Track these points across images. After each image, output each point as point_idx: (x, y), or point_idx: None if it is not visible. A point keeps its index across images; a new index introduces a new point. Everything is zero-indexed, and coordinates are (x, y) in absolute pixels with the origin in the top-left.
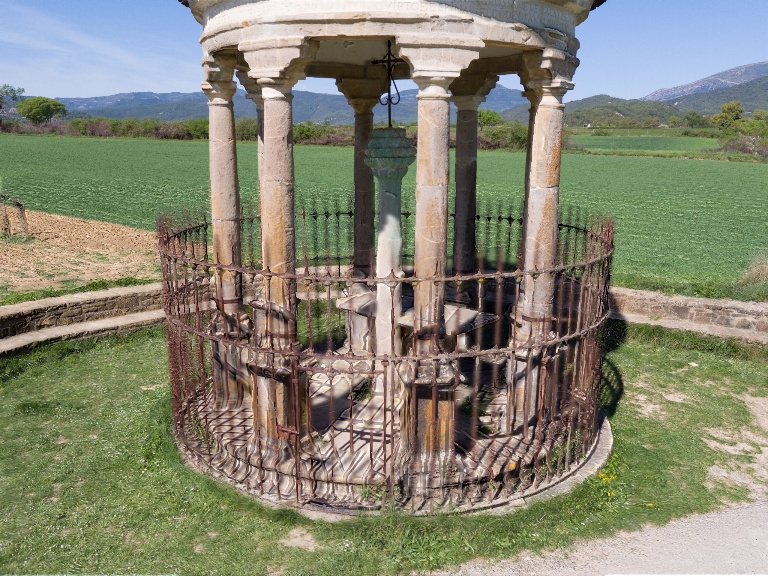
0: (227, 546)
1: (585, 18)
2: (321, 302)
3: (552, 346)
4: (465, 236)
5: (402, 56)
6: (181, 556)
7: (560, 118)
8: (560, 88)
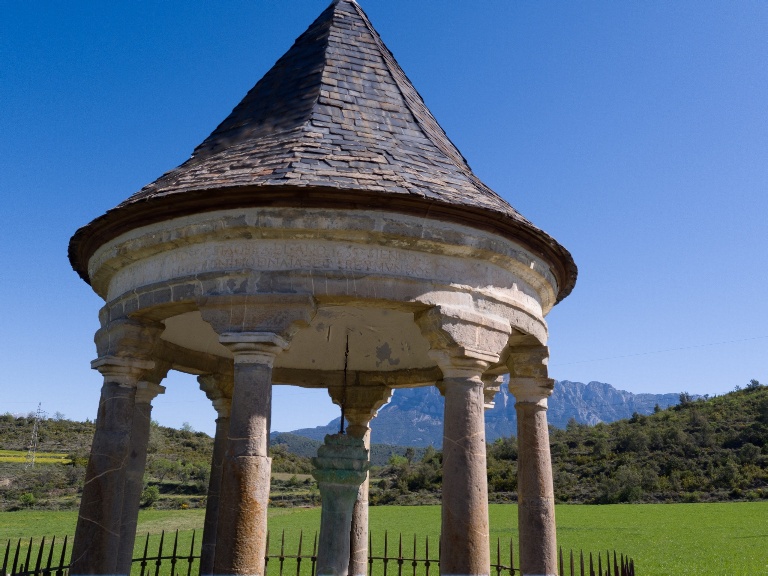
0: None
1: None
2: None
3: None
4: None
5: (494, 391)
6: None
7: None
8: None
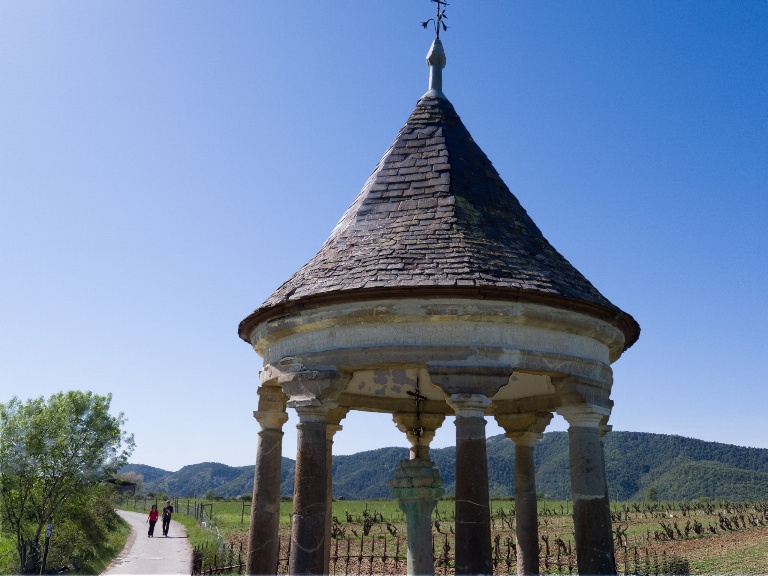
0: None
1: (374, 317)
2: None
3: None
4: None
5: None
6: None
7: None
8: None
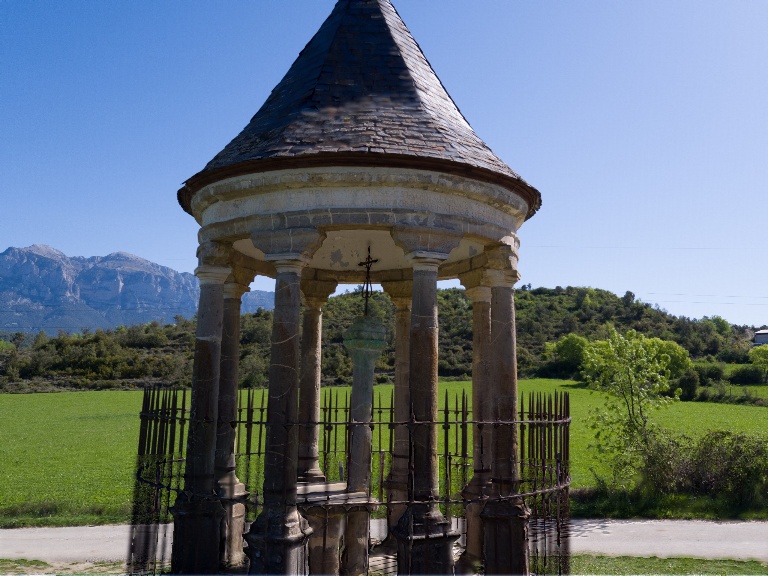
0: (543, 568)
1: None
2: None
3: None
4: None
5: None
6: (570, 568)
7: None
8: None
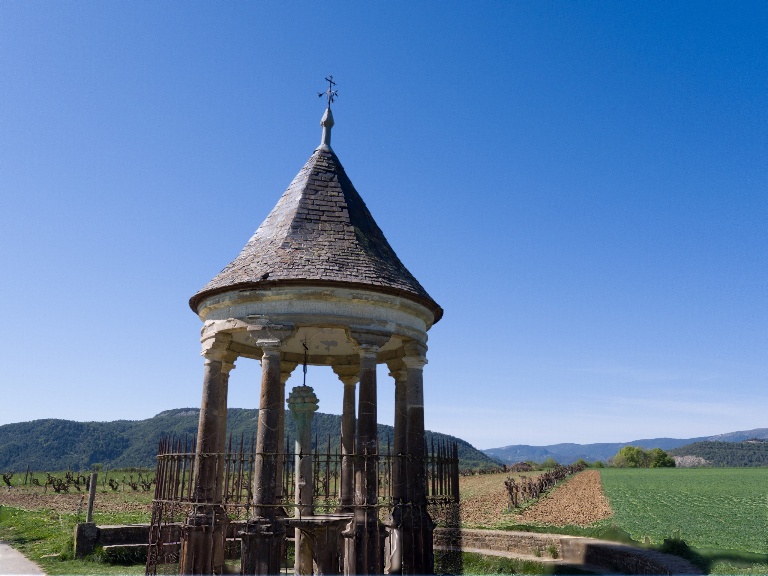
0: None
1: (322, 296)
2: (518, 562)
3: (251, 526)
4: (407, 471)
5: None
6: None
7: (266, 365)
8: (262, 347)
